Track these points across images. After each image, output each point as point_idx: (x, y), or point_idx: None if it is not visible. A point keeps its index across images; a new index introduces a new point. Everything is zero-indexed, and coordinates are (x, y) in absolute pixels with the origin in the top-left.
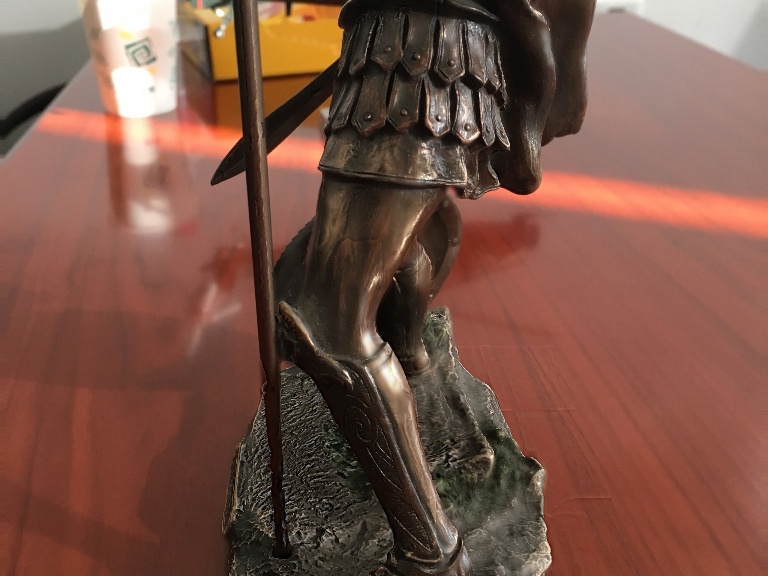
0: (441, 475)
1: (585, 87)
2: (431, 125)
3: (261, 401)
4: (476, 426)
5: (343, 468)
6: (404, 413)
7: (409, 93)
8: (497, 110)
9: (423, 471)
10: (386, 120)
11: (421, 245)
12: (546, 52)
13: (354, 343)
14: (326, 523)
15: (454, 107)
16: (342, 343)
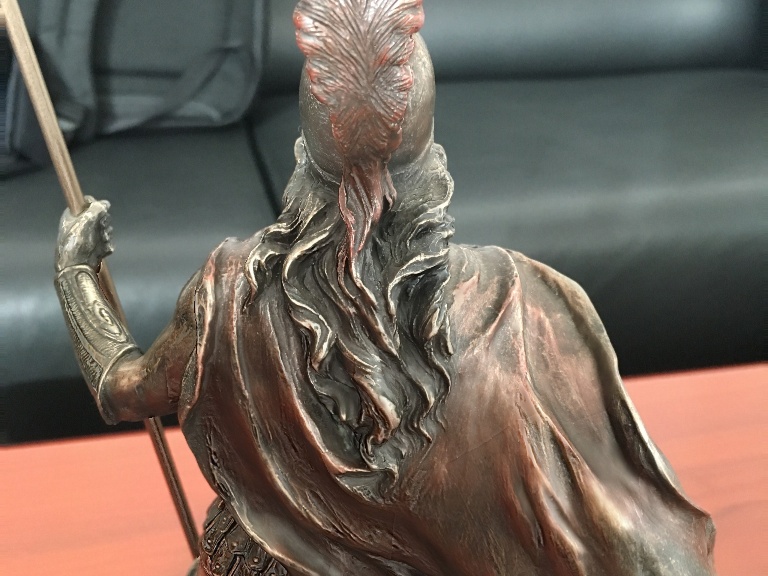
0: None
1: None
2: (203, 540)
3: None
4: None
5: None
6: None
7: (216, 510)
8: None
9: None
10: None
11: None
12: None
13: None
14: None
15: (218, 546)
16: None
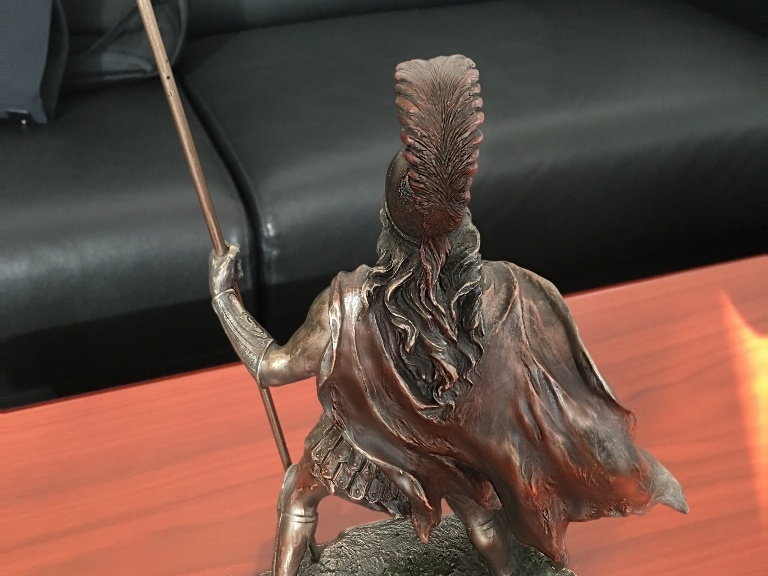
0: None
1: (543, 538)
2: (313, 455)
3: (447, 514)
4: None
5: (389, 570)
6: (284, 546)
7: None
8: (363, 480)
9: (285, 575)
10: (310, 437)
11: (486, 523)
12: (395, 480)
13: (287, 502)
14: (340, 572)
15: None
16: None
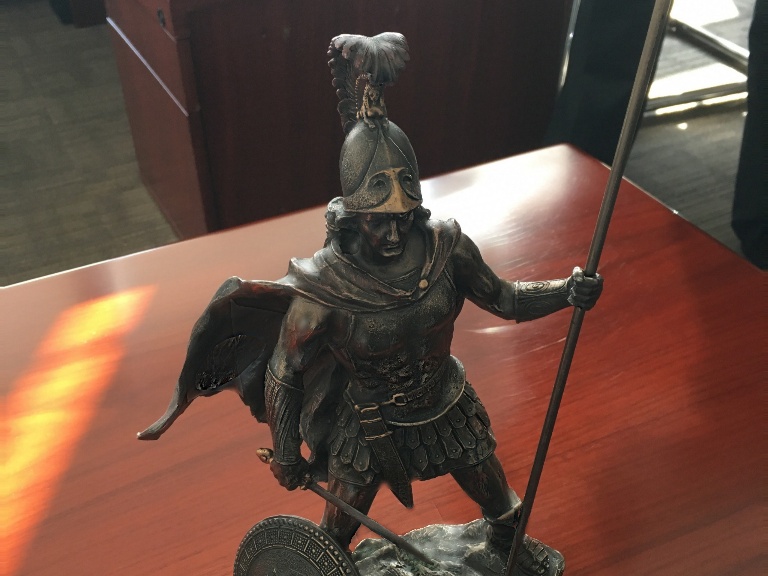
0: (412, 569)
1: None
2: None
3: None
4: (365, 559)
5: None
6: None
7: None
8: None
9: None
10: None
11: None
12: None
13: None
14: None
15: None
16: (513, 494)
